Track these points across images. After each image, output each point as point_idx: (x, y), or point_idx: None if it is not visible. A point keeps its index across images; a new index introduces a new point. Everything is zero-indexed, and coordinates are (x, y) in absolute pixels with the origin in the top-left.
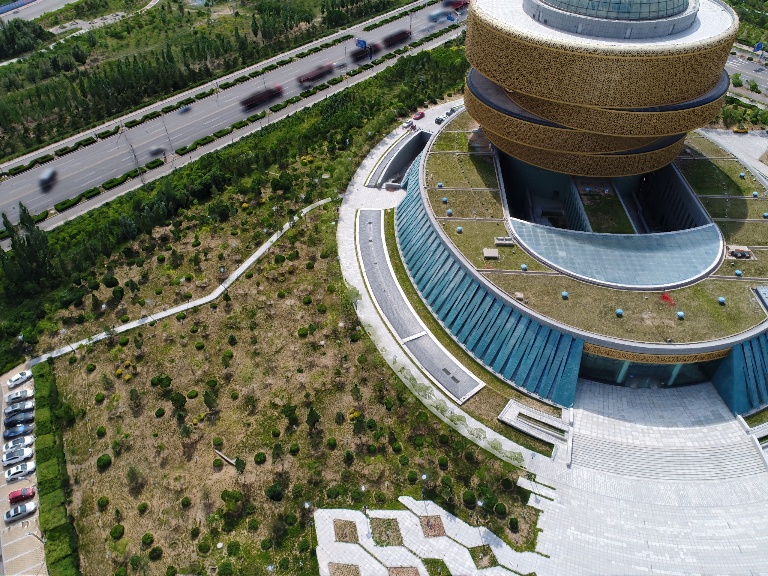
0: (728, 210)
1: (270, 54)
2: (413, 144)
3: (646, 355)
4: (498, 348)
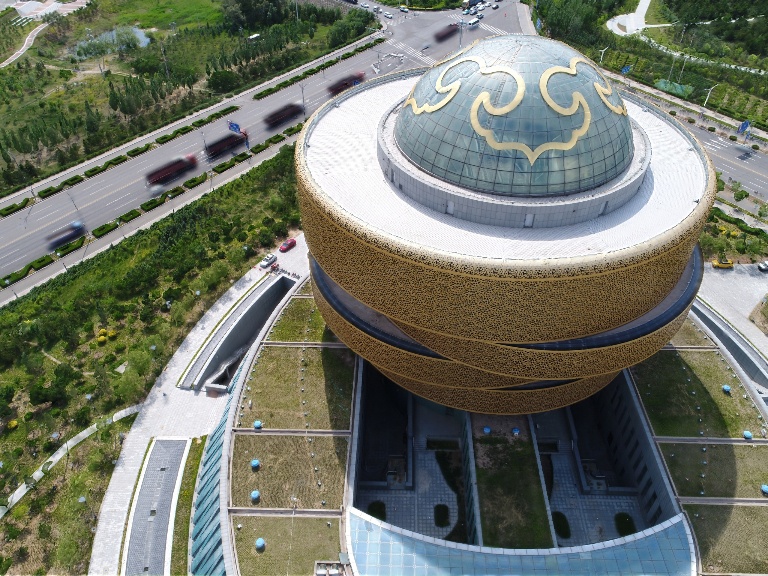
0: (705, 475)
1: (128, 135)
2: (270, 296)
3: None
4: None
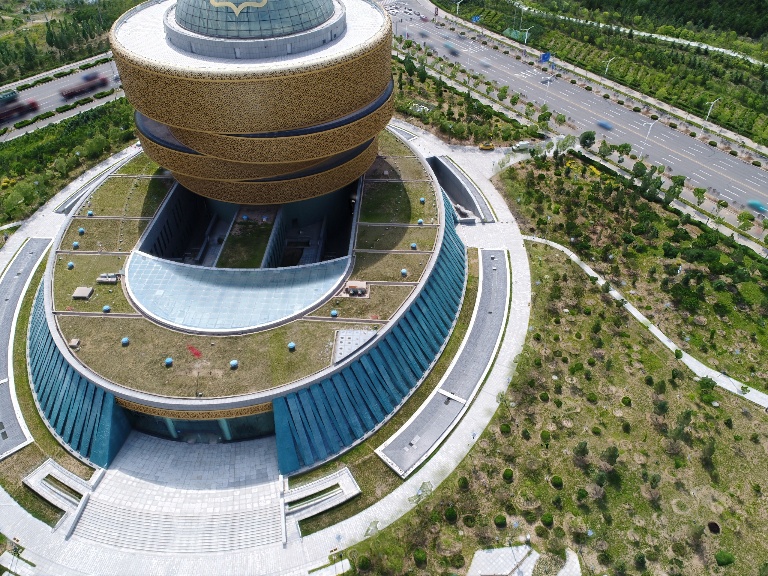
0: (379, 240)
1: None
2: None
3: (174, 411)
4: (53, 400)
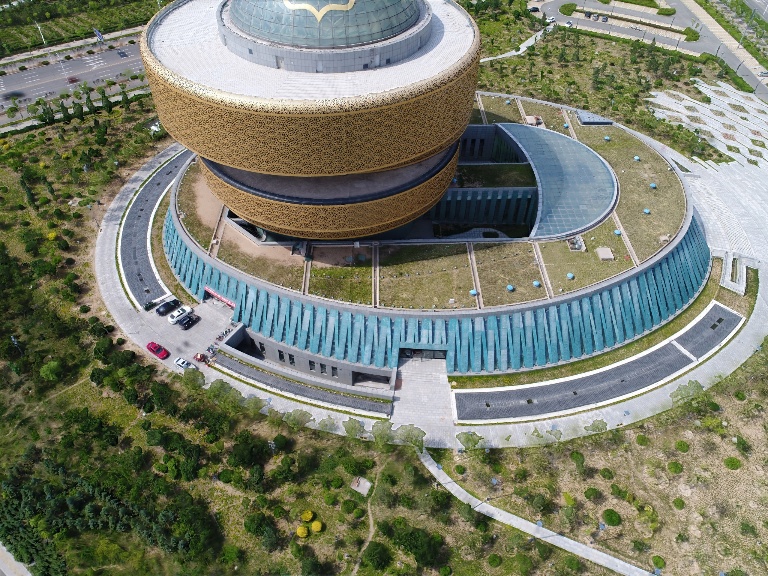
0: None
1: None
2: None
3: None
4: None
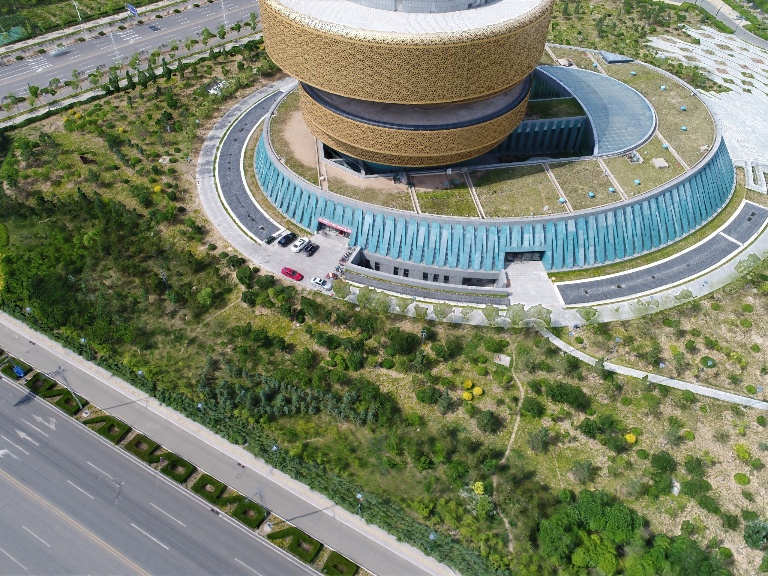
0: None
1: None
2: None
3: None
4: None
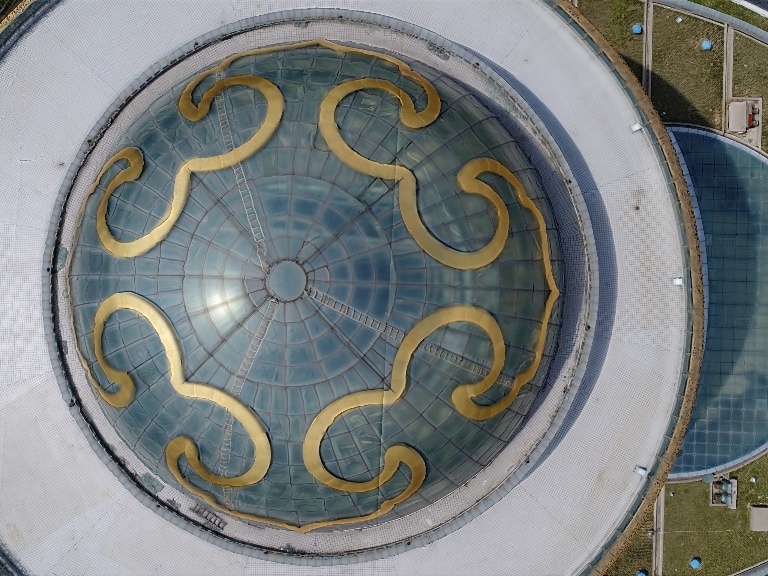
0: None
1: None
2: None
3: None
4: None
